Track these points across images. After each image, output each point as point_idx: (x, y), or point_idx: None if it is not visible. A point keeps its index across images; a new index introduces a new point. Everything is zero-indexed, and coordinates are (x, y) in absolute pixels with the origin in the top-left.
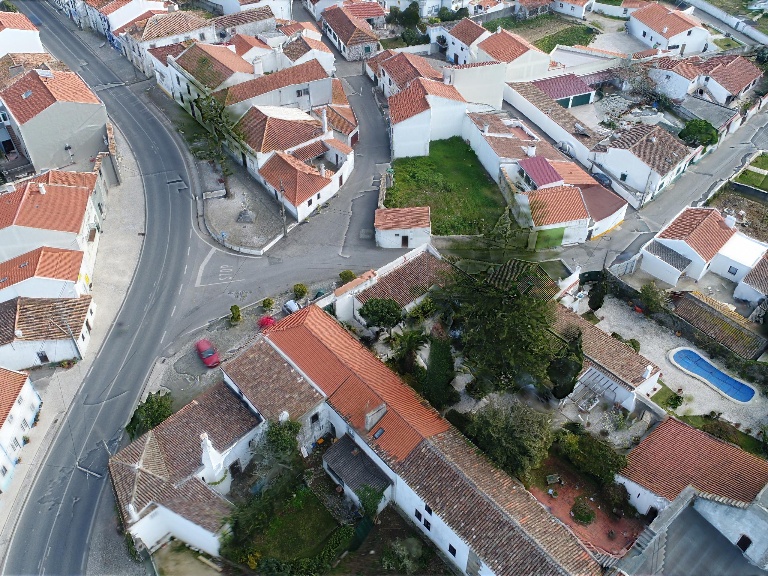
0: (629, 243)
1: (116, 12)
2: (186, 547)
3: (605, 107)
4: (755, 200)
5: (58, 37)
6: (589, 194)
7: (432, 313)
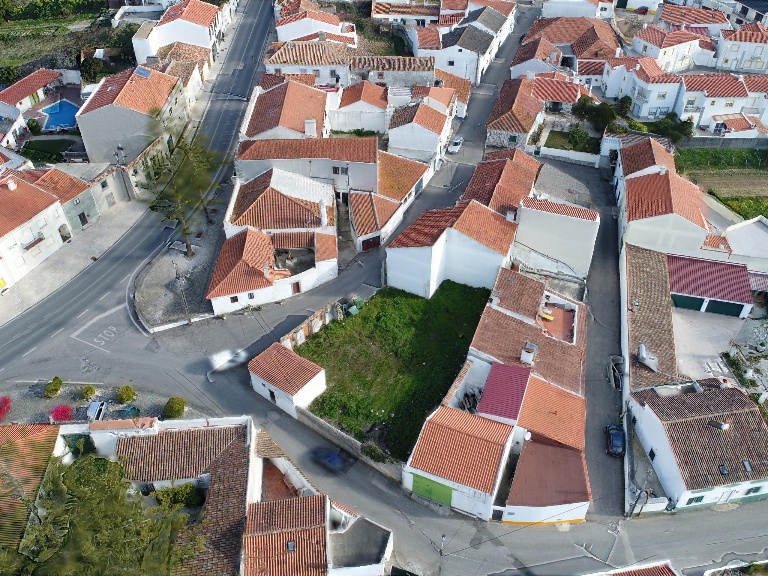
0: (550, 559)
1: (286, 26)
2: None
3: (759, 332)
4: None
5: (251, 35)
6: (549, 457)
7: (180, 506)
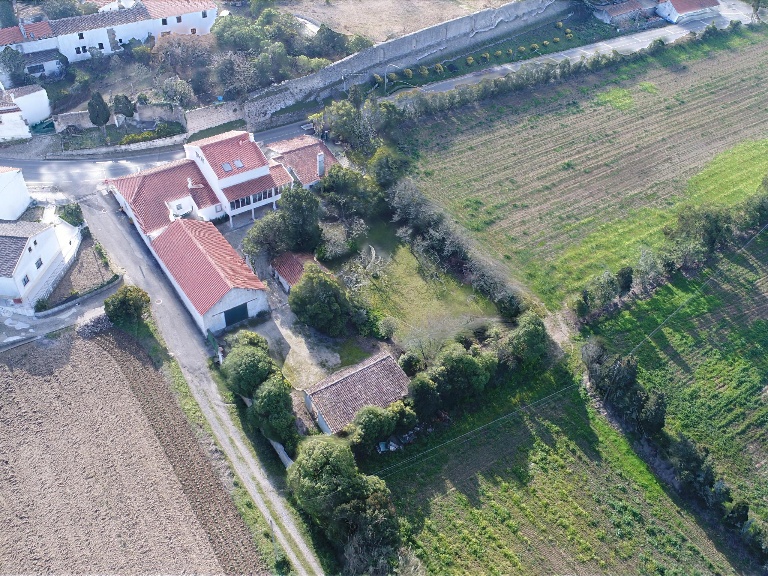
0: None
1: None
2: (35, 126)
3: None
4: None
5: None
6: None
7: None
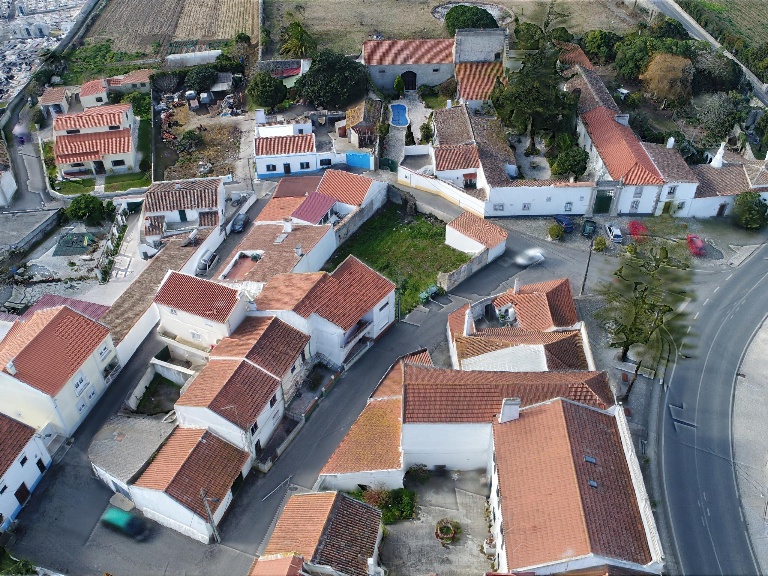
0: None
1: None
2: None
3: None
4: (163, 173)
5: None
6: (296, 195)
7: None
